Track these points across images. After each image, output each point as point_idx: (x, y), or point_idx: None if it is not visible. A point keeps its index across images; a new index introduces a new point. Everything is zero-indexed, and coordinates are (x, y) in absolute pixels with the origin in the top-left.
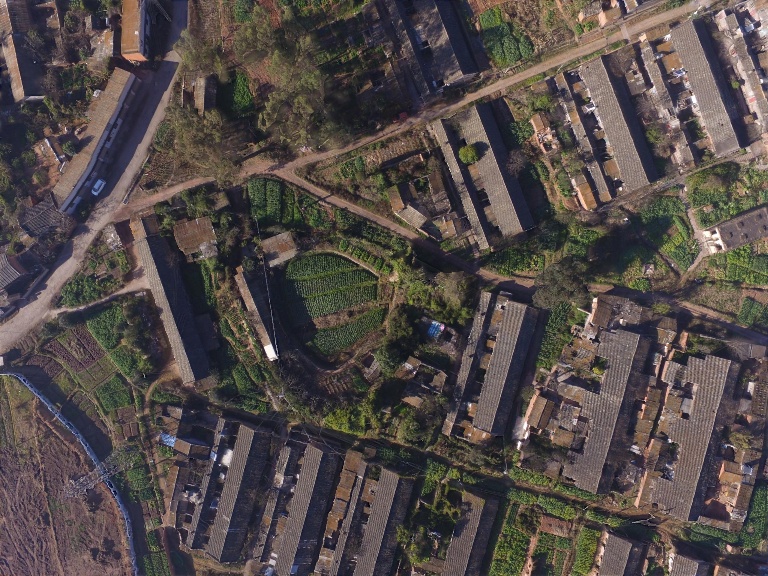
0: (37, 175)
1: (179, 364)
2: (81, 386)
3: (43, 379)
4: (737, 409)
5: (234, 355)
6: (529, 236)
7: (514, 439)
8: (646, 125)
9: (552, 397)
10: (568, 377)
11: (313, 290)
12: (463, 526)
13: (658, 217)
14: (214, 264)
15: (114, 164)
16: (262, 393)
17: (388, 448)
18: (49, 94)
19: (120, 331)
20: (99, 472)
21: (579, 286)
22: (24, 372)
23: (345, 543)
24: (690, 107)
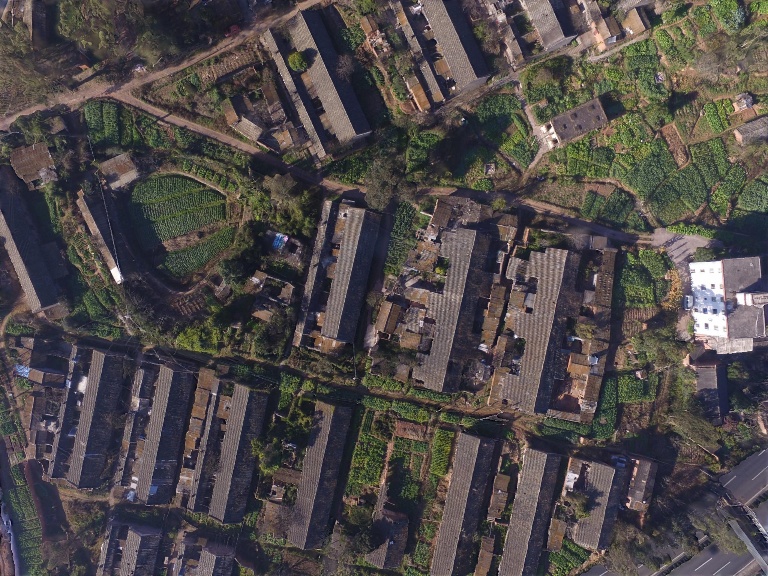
0: None
1: (26, 293)
2: None
3: None
4: (582, 301)
5: (84, 282)
6: (369, 143)
7: (366, 347)
8: (473, 21)
9: (399, 302)
10: (416, 281)
11: (161, 213)
12: (316, 435)
13: (496, 116)
14: (51, 188)
15: None
16: (114, 318)
17: (242, 364)
18: None
19: None
20: None
21: (402, 179)
22: None
23: (203, 461)
24: (519, 2)
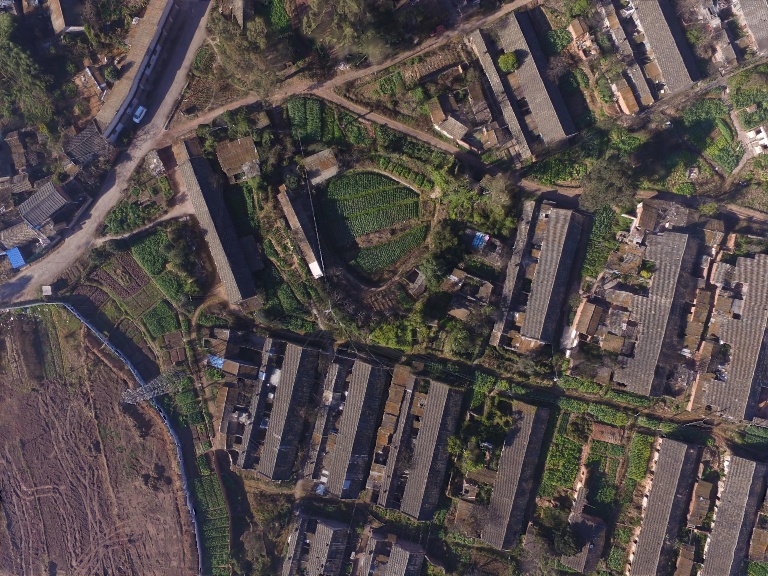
0: (79, 106)
1: (225, 285)
2: (128, 313)
3: (90, 308)
4: None
5: (279, 276)
6: (570, 145)
7: (562, 348)
8: (686, 25)
9: (600, 304)
10: (615, 284)
11: (355, 209)
12: (515, 435)
13: (701, 120)
14: (258, 182)
15: (154, 91)
16: (308, 312)
17: (436, 362)
18: (89, 22)
19: (167, 251)
20: (153, 386)
21: (627, 181)
22: (71, 302)
23: (396, 457)
24: (730, 7)
